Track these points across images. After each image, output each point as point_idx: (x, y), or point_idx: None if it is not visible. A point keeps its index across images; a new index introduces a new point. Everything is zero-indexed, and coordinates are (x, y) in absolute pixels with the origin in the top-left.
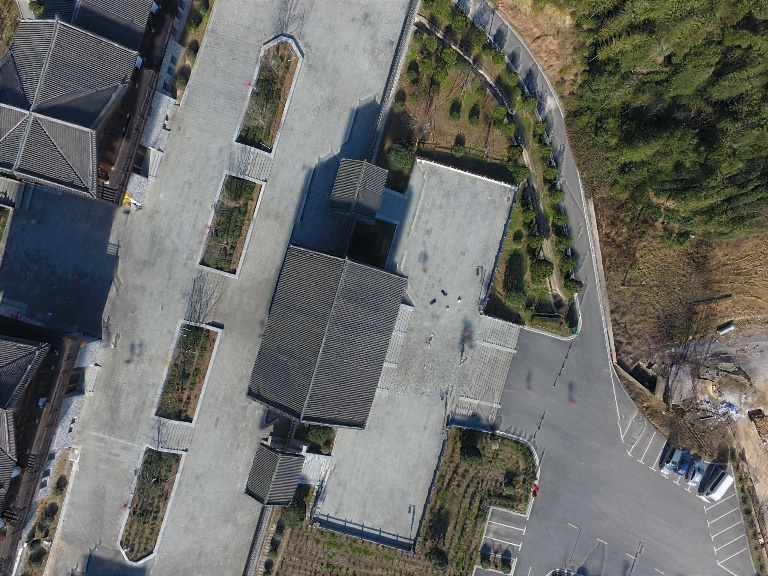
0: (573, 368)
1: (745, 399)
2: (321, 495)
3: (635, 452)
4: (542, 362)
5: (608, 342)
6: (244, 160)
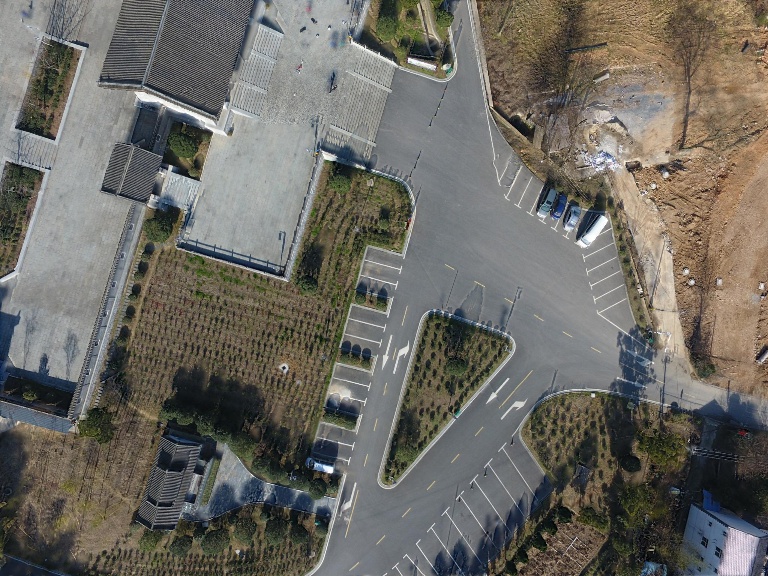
0: (449, 110)
1: (622, 150)
2: (190, 220)
3: (512, 196)
4: (417, 102)
5: (484, 85)
6: None
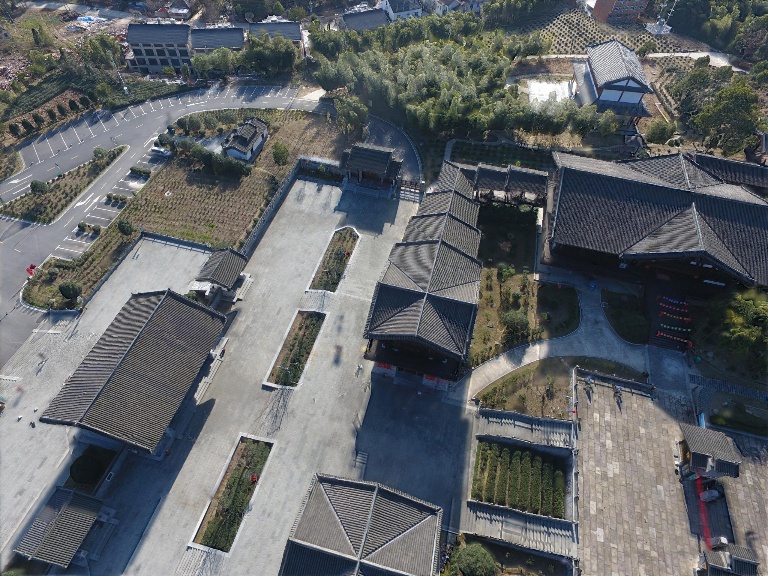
0: None
1: None
2: None
3: None
4: None
5: None
6: (204, 572)
